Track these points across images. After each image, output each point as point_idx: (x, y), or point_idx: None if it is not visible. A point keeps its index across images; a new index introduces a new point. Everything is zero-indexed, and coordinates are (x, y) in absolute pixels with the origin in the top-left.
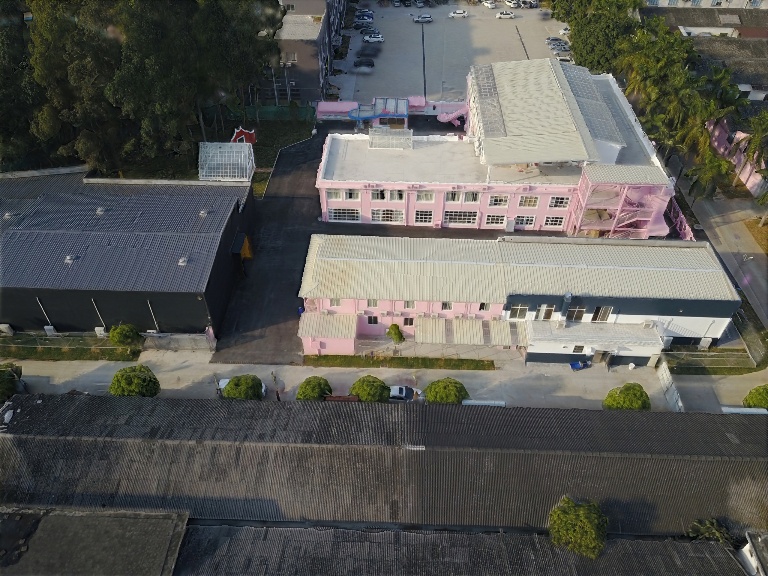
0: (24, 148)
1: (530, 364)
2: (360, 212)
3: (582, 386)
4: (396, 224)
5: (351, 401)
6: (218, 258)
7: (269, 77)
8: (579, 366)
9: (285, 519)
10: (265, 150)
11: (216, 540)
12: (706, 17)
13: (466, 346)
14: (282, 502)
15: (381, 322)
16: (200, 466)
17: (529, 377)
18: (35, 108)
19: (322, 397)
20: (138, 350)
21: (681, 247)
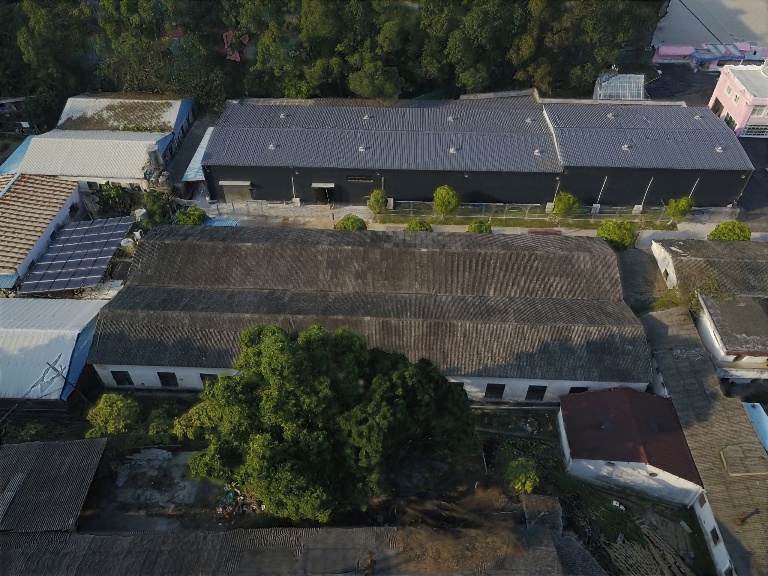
0: (486, 74)
1: None
2: None
3: None
4: None
5: None
6: None
7: None
8: None
9: None
10: None
11: None
12: None
13: None
14: None
15: None
16: None
17: None
18: (516, 37)
19: None
20: (674, 223)
21: None
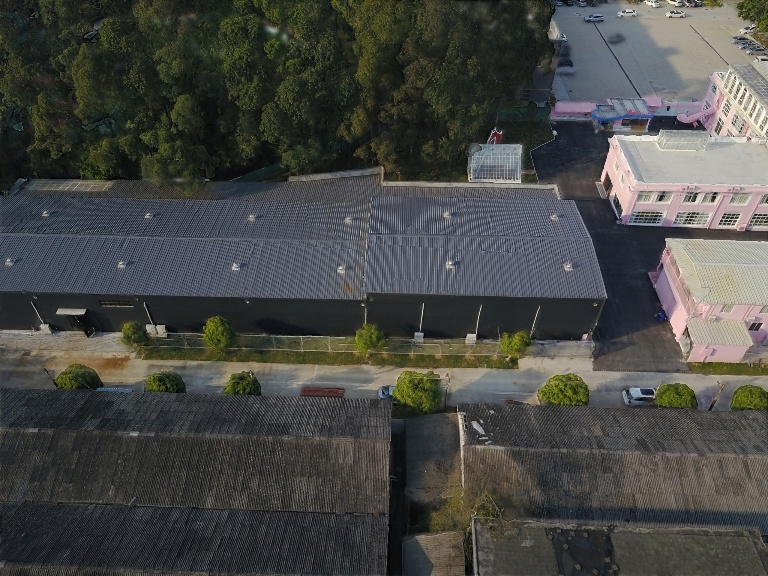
0: (319, 150)
1: None
2: (664, 215)
3: None
4: (697, 227)
5: None
6: None
7: None
8: None
9: None
10: None
11: None
12: None
13: None
14: None
15: (764, 329)
16: (712, 480)
17: None
18: (347, 110)
19: None
20: (515, 357)
21: None
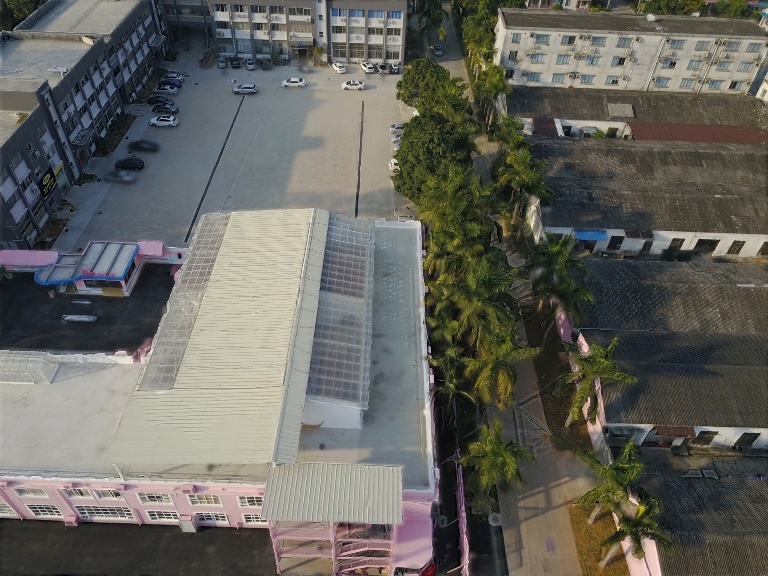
0: None
1: None
2: None
3: None
4: (6, 517)
5: None
6: None
7: None
8: None
9: None
10: None
11: None
12: (591, 106)
13: None
14: None
15: None
16: None
17: None
18: None
19: None
20: None
21: None
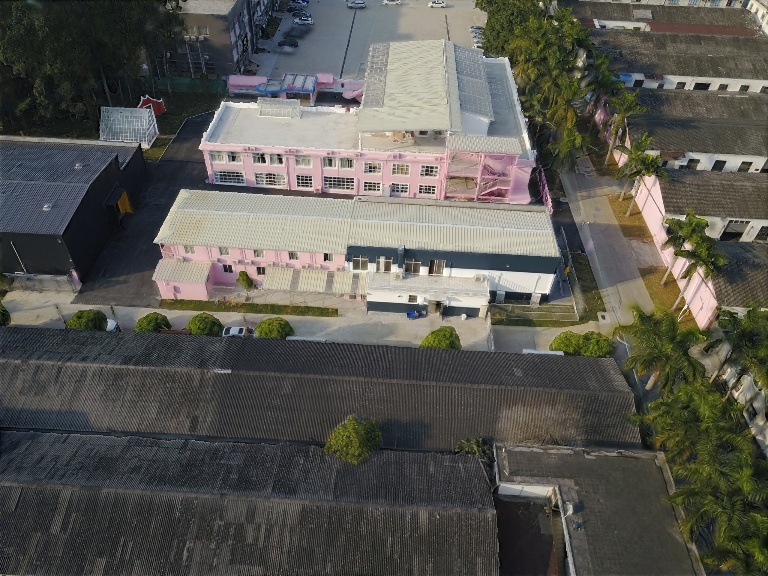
0: None
1: (371, 313)
2: (244, 175)
3: (414, 333)
4: (279, 188)
5: (181, 334)
6: (85, 206)
7: (183, 50)
8: (415, 315)
9: (92, 429)
10: (172, 119)
11: (18, 442)
12: (621, 11)
13: (315, 295)
14: (92, 415)
15: (236, 271)
16: (22, 382)
17: (367, 324)
18: None
19: (157, 330)
20: (5, 290)
21: (523, 211)
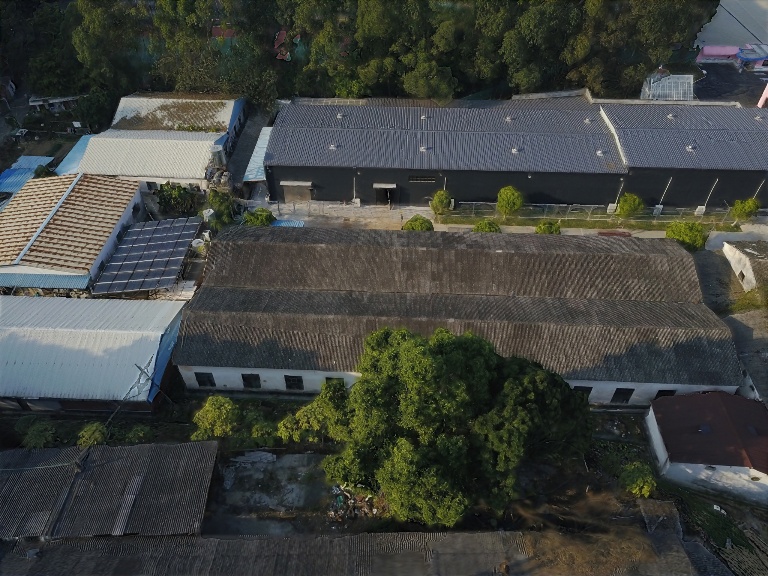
0: None
1: None
2: None
3: None
4: None
5: None
6: None
7: None
8: None
9: None
10: None
11: None
12: None
13: None
14: None
15: None
16: None
17: None
18: (570, 37)
19: None
20: (738, 224)
21: None
